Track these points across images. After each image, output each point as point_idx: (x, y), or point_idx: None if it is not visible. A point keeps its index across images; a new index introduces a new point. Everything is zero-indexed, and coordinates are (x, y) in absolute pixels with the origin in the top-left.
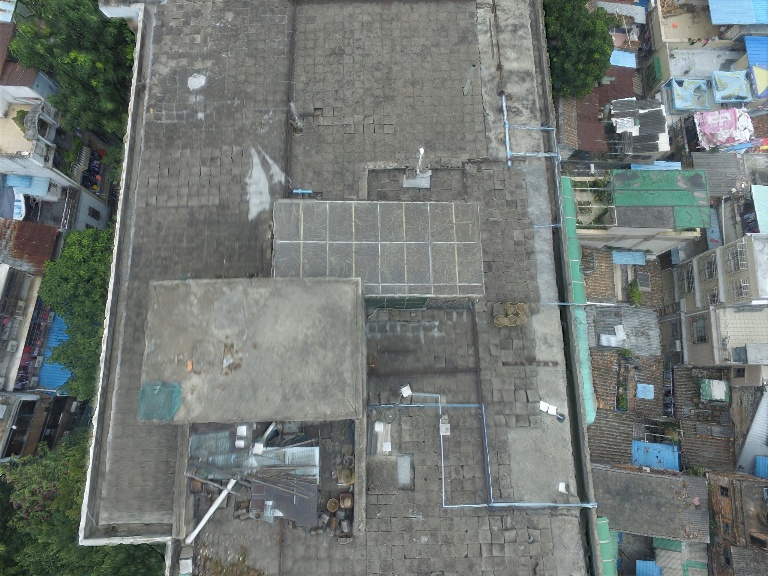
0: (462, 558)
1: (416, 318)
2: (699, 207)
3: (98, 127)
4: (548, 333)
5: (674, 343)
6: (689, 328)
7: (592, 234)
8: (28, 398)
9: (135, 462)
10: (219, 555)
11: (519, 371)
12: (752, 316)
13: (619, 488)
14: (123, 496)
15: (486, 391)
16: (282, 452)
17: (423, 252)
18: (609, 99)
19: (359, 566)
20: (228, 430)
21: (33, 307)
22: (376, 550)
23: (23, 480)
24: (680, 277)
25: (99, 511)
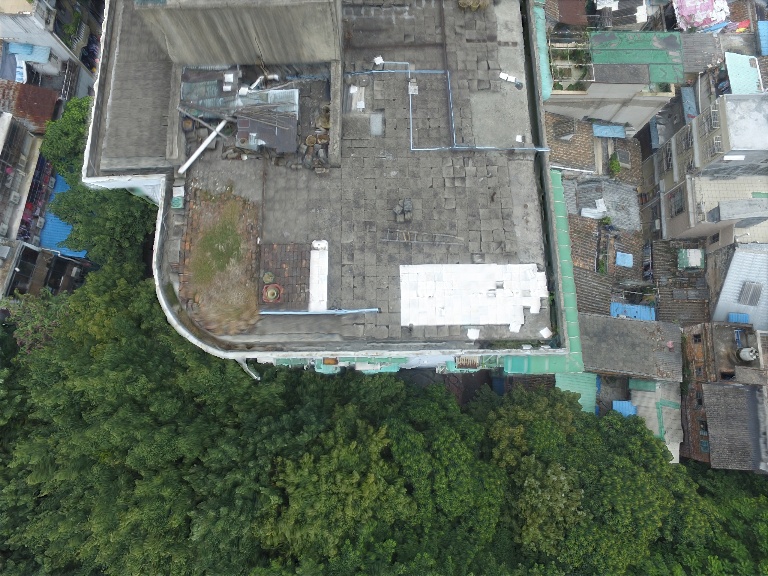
0: (427, 188)
1: (388, 2)
2: (673, 65)
3: None
4: (509, 20)
5: (654, 223)
6: (667, 205)
7: (572, 96)
8: (30, 246)
9: (133, 117)
10: (208, 187)
11: (481, 46)
12: (726, 184)
13: (596, 330)
14: (122, 143)
15: (451, 61)
16: (265, 93)
17: None
18: None
19: (334, 194)
20: (217, 79)
21: (35, 165)
22: (350, 182)
23: (26, 319)
24: (659, 159)
25: (100, 162)
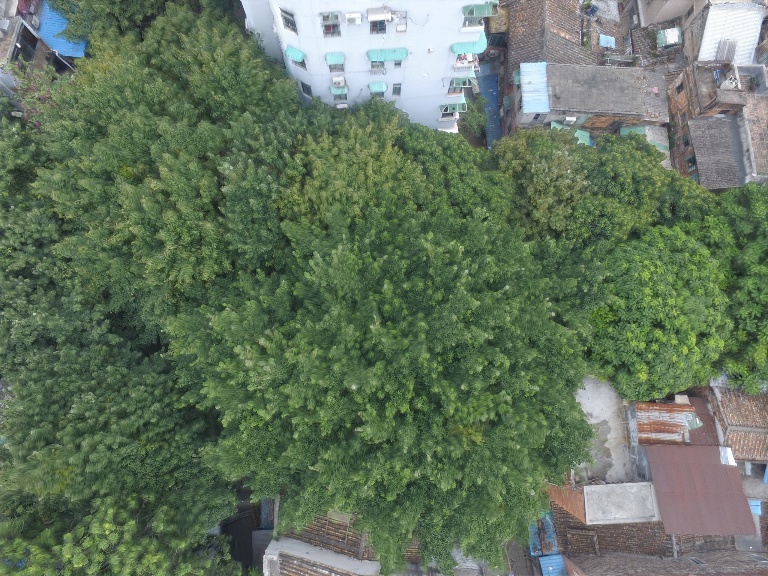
0: None
1: None
2: None
3: None
4: None
5: (632, 19)
6: None
7: None
8: (29, 28)
9: None
10: None
11: None
12: None
13: (586, 78)
14: None
15: None
16: None
17: None
18: None
19: None
20: None
21: None
22: None
23: None
24: None
25: None
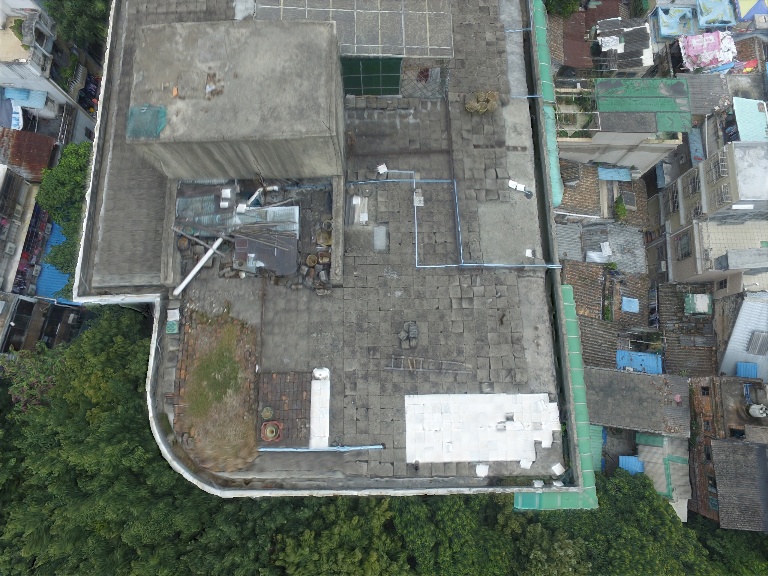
0: (433, 310)
1: (392, 105)
2: (681, 113)
3: (94, 42)
4: (517, 123)
5: (659, 264)
6: (674, 247)
7: (577, 143)
8: (26, 298)
9: (126, 231)
10: (205, 308)
11: (489, 153)
12: (734, 229)
13: (602, 384)
14: (115, 259)
15: (458, 169)
16: (264, 210)
17: (396, 20)
18: (595, 22)
19: (336, 317)
20: (213, 194)
21: (31, 214)
22: (353, 303)
23: (21, 374)
24: (665, 199)
25: (92, 277)
